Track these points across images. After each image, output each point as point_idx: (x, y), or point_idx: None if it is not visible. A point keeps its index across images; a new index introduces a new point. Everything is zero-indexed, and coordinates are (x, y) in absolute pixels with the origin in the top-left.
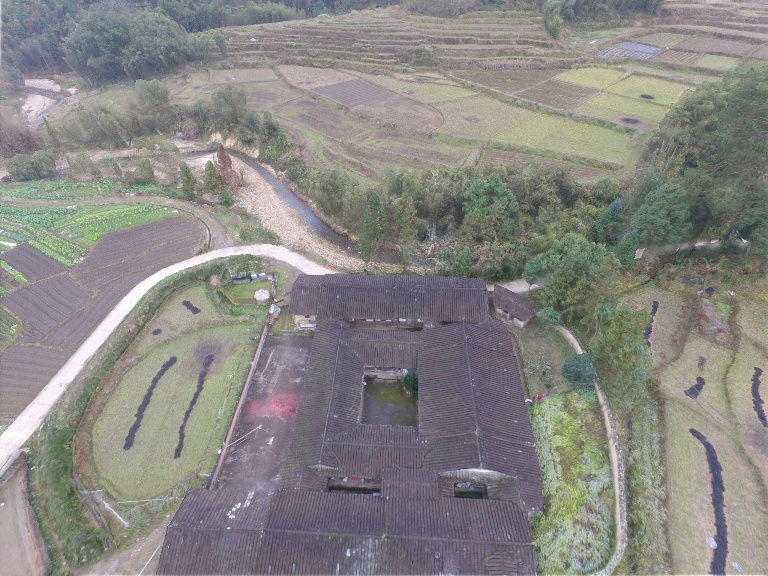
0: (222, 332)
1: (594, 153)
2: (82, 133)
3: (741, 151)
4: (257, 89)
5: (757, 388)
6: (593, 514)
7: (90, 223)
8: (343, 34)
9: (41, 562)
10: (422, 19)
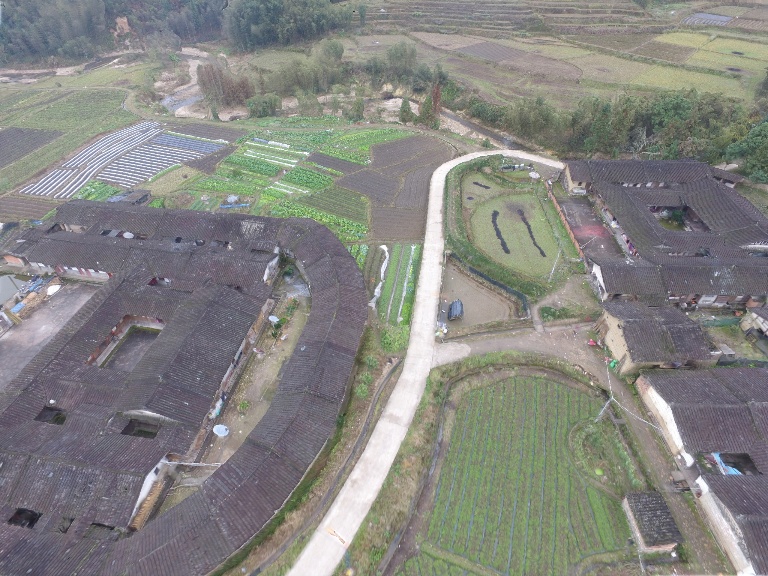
0: (517, 198)
1: (717, 91)
2: (281, 83)
3: None
4: None
5: None
6: None
7: (353, 140)
8: (462, 5)
9: (506, 300)
10: None
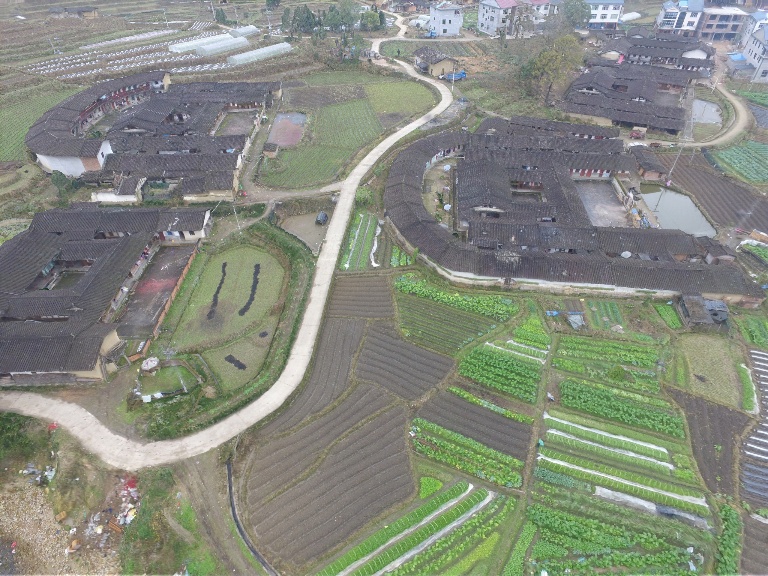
0: (200, 338)
1: None
2: None
3: None
4: None
5: None
6: None
7: (463, 526)
8: None
9: None
10: None
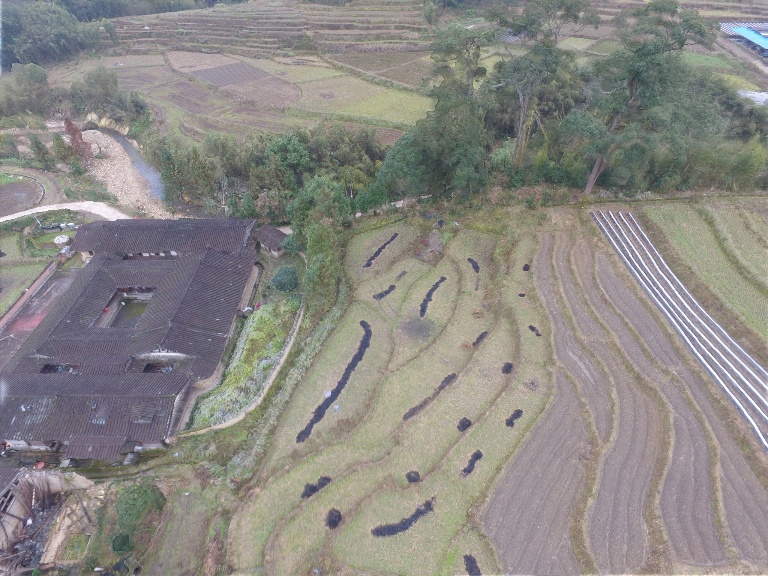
0: (18, 270)
1: None
2: None
3: (440, 99)
4: (140, 73)
5: (433, 291)
6: (250, 381)
7: None
8: (232, 21)
9: None
10: (311, 7)
